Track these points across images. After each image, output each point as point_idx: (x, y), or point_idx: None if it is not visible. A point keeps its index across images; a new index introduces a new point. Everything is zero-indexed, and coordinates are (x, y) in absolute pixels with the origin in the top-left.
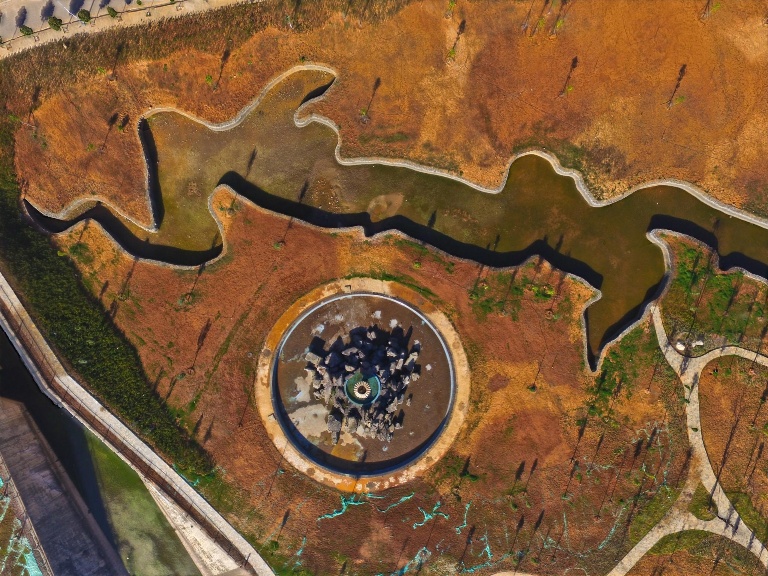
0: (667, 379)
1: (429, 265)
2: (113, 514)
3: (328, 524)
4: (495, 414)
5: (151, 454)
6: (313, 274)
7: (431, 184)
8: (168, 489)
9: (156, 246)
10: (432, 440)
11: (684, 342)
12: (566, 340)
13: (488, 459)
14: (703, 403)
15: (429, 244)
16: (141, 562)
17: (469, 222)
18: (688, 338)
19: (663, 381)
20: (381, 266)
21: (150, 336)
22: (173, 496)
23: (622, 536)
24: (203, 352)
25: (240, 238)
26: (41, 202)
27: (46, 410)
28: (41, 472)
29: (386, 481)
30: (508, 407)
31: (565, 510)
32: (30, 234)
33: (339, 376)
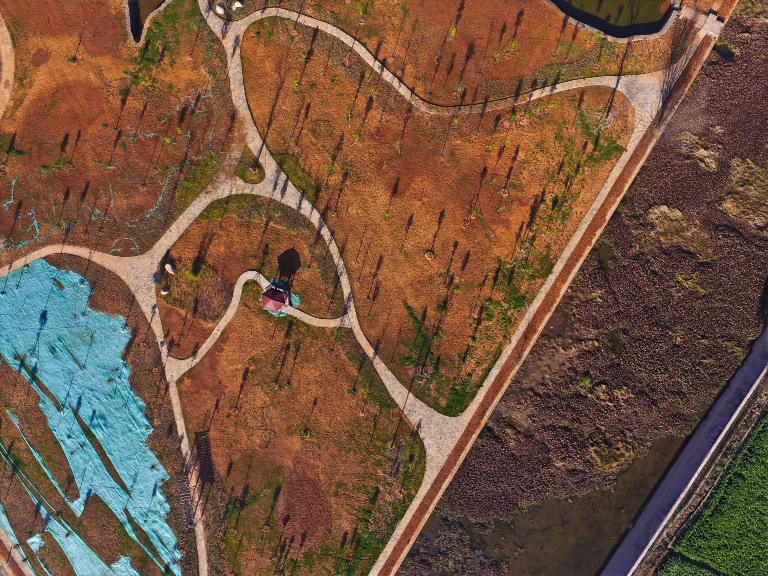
0: (209, 44)
1: None
2: None
3: None
4: (39, 89)
5: None
6: None
7: None
8: None
9: None
10: None
11: (223, 5)
12: (107, 11)
13: (33, 134)
14: (246, 66)
15: None
16: None
17: None
18: (228, 2)
19: (205, 46)
20: None
21: None
22: None
23: (169, 203)
24: None
25: None
26: None
27: None
28: None
29: None
30: (51, 81)
31: (110, 180)
32: None
33: None
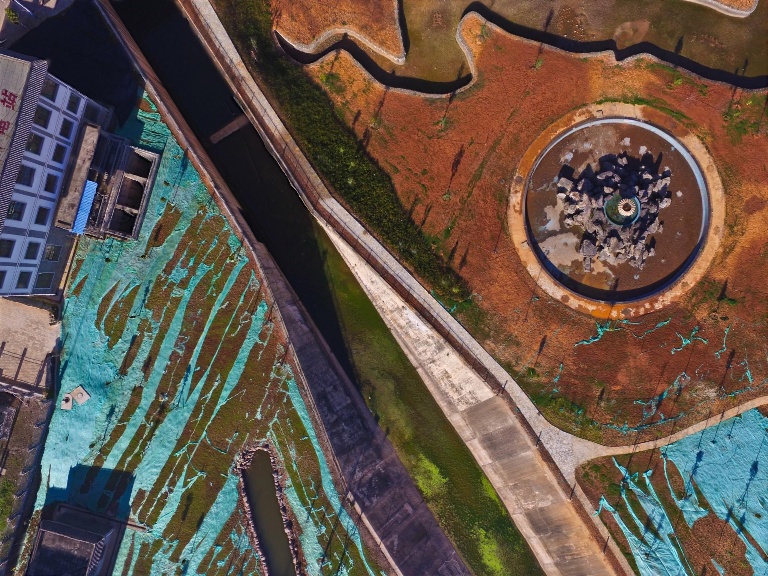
0: None
1: (682, 87)
2: (354, 354)
3: (585, 350)
4: (752, 237)
5: (410, 279)
6: (565, 99)
7: (677, 10)
8: (426, 315)
9: (402, 78)
10: (686, 266)
11: None
12: None
13: (746, 282)
14: None
15: (681, 67)
16: (383, 401)
17: (717, 47)
18: None
19: None
20: (633, 90)
21: (404, 164)
22: (431, 322)
23: None
24: (457, 178)
25: (491, 65)
26: (292, 33)
27: (287, 250)
28: (292, 306)
29: (641, 307)
30: (766, 229)
31: None
32: (285, 63)
33: (600, 196)
